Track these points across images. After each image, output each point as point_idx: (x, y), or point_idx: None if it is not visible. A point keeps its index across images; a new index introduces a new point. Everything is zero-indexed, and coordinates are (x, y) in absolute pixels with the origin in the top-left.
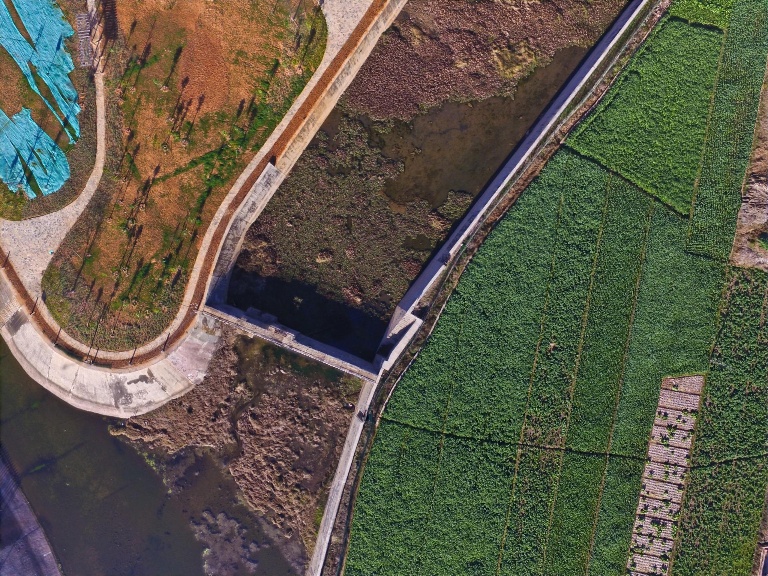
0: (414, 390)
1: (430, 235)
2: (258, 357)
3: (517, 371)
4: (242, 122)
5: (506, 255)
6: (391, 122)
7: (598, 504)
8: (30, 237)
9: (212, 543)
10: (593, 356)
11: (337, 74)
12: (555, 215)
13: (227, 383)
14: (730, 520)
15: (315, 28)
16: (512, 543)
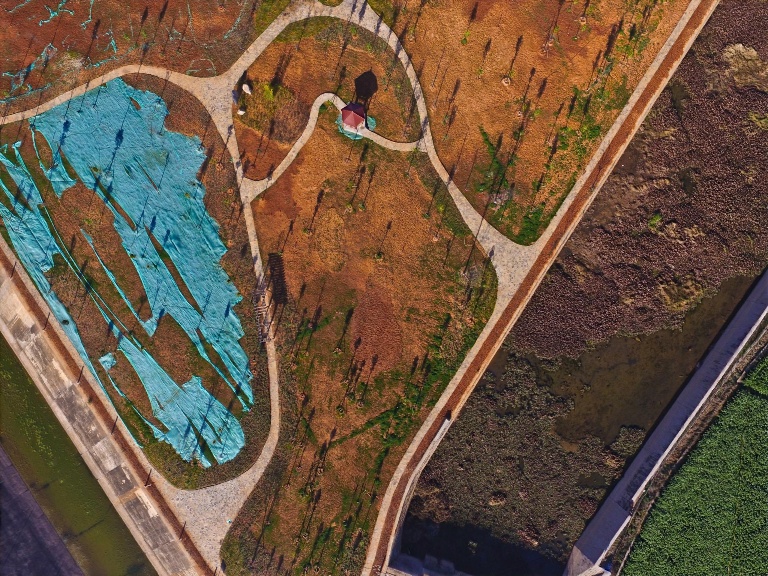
0: None
1: (604, 473)
2: None
3: None
4: (416, 379)
5: (690, 500)
6: (559, 360)
7: None
8: (206, 507)
9: None
10: None
11: (509, 324)
12: (738, 457)
13: None
14: None
15: (486, 280)
16: None
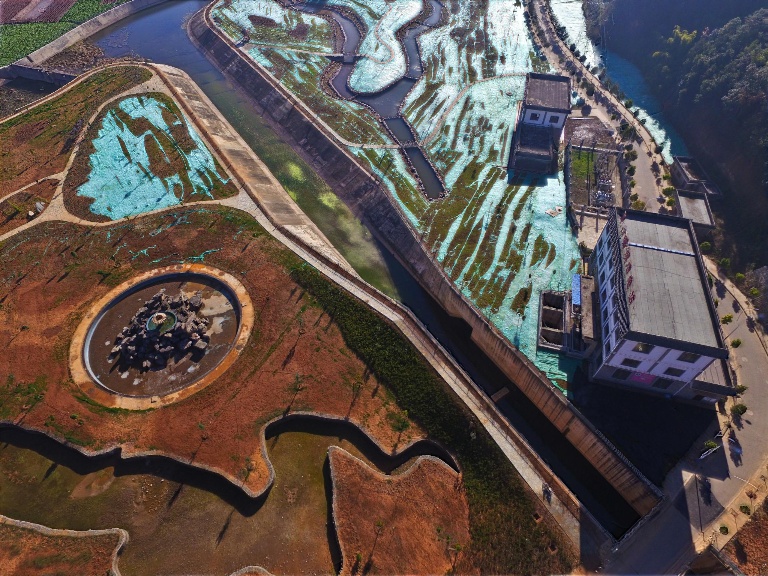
0: (0, 64)
1: None
2: None
3: None
4: None
5: None
6: None
7: None
8: None
9: None
10: None
11: None
12: None
13: None
14: None
15: None
16: None
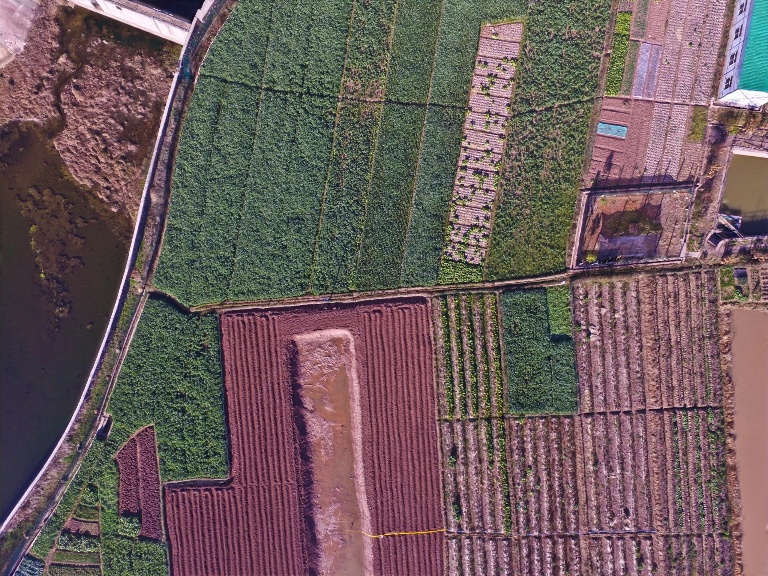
0: (230, 42)
1: None
2: (80, 28)
3: (333, 20)
4: None
5: None
6: None
7: (419, 155)
8: None
9: (38, 219)
10: (410, 3)
11: None
12: None
13: (48, 54)
14: (551, 168)
15: None
16: (333, 196)
